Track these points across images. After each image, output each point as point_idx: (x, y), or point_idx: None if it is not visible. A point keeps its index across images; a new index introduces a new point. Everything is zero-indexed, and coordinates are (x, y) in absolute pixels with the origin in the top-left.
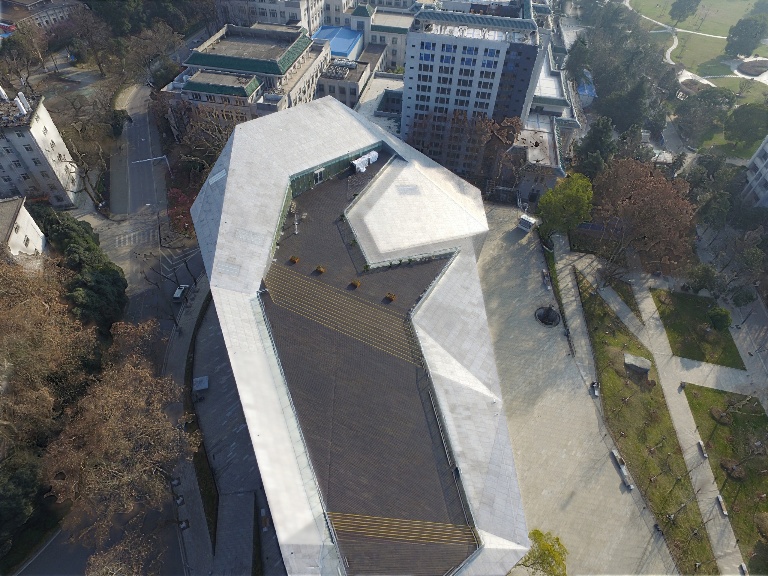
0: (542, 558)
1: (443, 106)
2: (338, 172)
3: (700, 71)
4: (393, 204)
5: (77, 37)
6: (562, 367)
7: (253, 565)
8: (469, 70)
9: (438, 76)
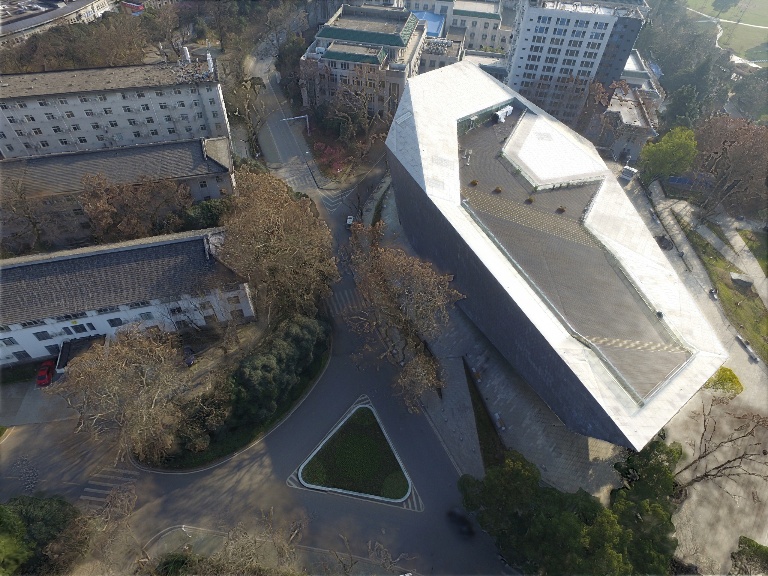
0: (724, 378)
1: (549, 74)
2: (483, 122)
3: (748, 56)
4: (536, 146)
5: (198, 16)
6: (683, 279)
7: (474, 406)
8: (578, 41)
9: (549, 47)
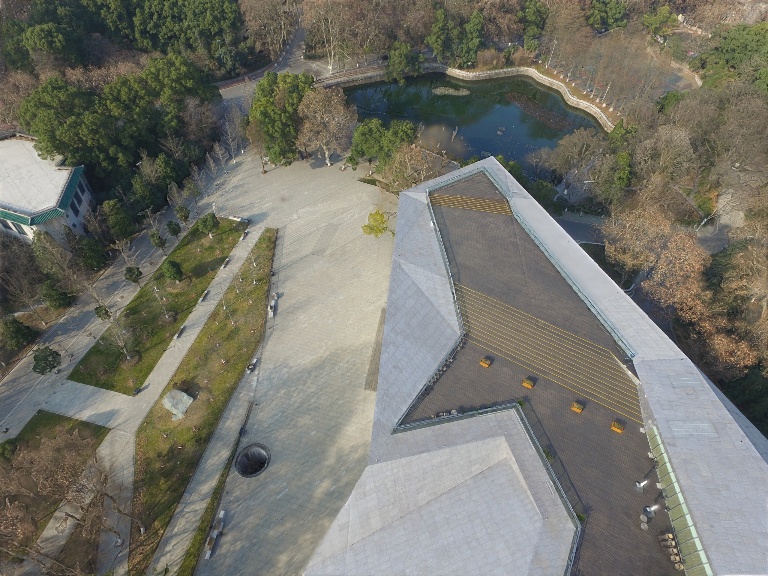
0: None
1: None
2: None
3: None
4: None
5: None
6: (273, 391)
7: None
8: None
9: None
